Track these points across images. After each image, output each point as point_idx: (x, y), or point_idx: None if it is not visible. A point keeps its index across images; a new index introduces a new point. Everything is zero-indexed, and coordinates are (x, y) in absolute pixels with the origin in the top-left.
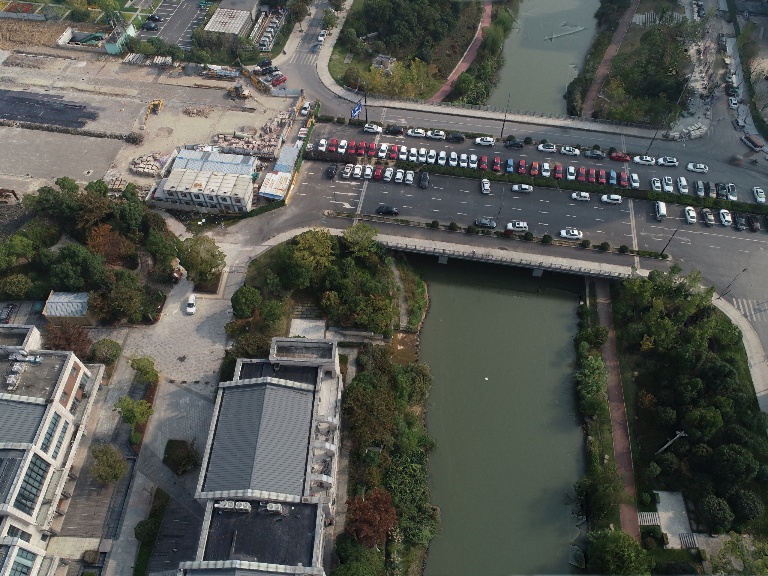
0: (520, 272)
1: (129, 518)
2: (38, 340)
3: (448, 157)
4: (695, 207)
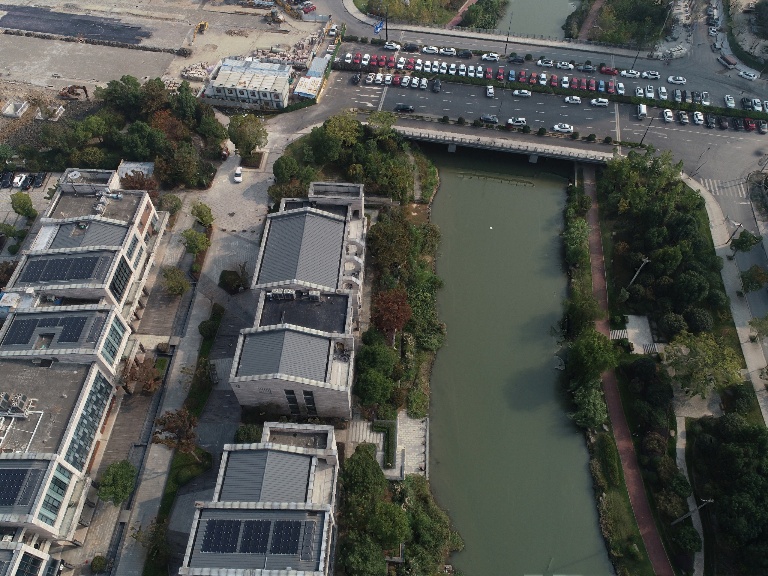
0: (518, 159)
1: (192, 323)
2: (118, 184)
3: (458, 69)
4: (672, 110)
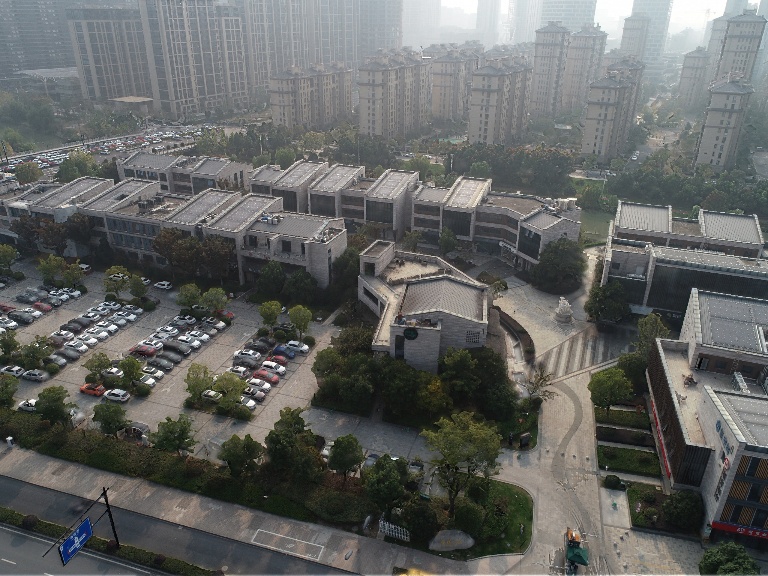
0: None
1: None
2: None
3: None
4: None
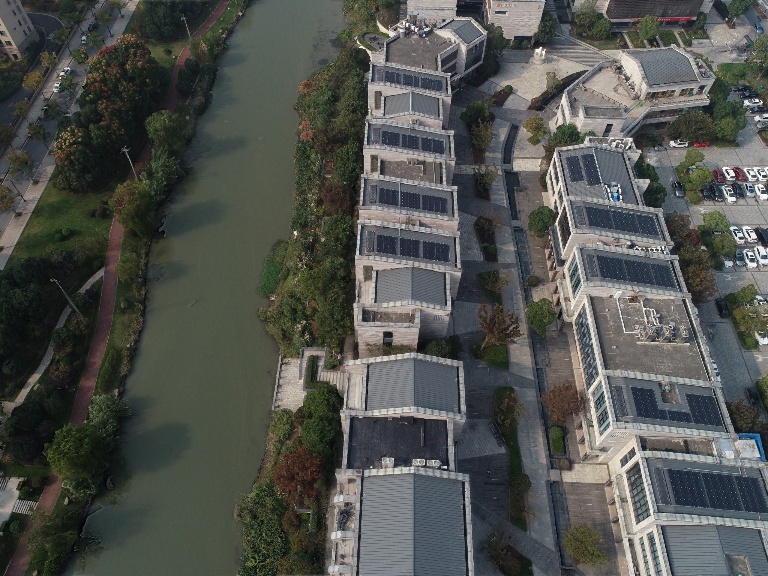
0: None
1: (544, 501)
2: None
3: None
4: None
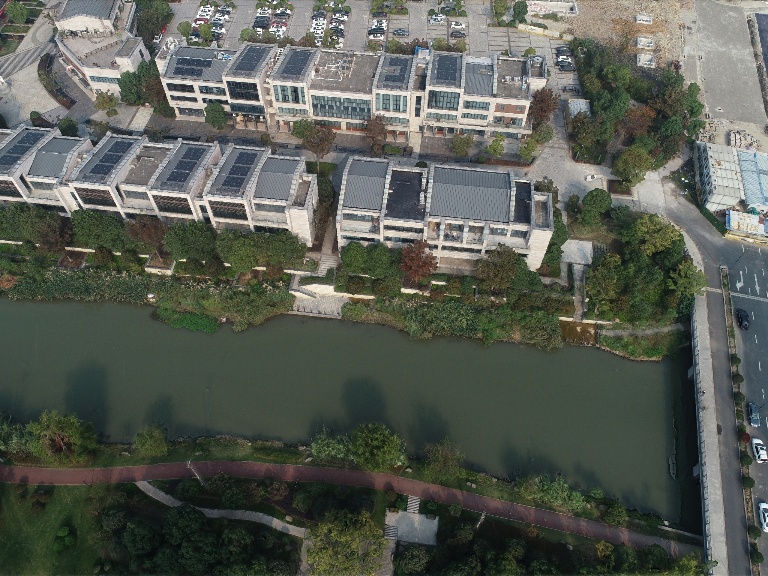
0: None
1: None
2: (540, 87)
3: None
4: None
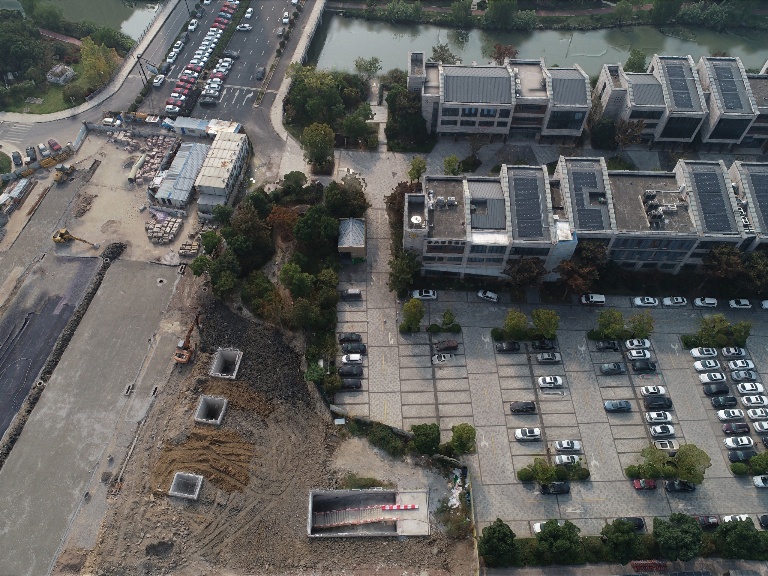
0: None
1: None
2: None
3: None
4: None
